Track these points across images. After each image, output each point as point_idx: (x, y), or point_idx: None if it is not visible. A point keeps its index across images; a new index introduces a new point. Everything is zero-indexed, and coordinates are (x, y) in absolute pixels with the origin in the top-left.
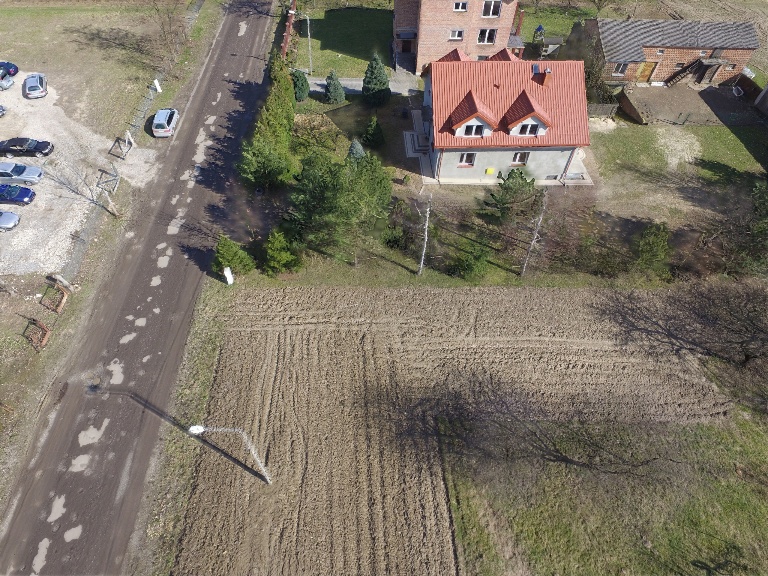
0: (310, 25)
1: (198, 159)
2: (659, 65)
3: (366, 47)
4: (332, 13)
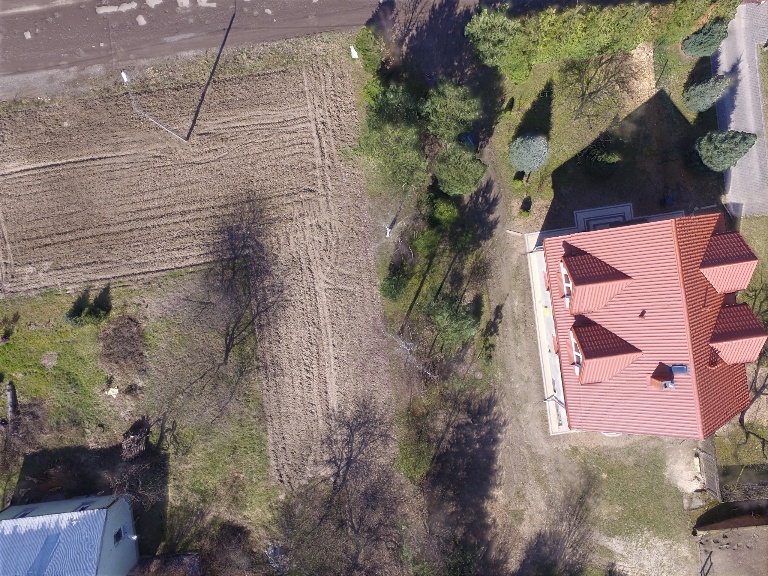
0: None
1: None
2: None
3: None
4: None
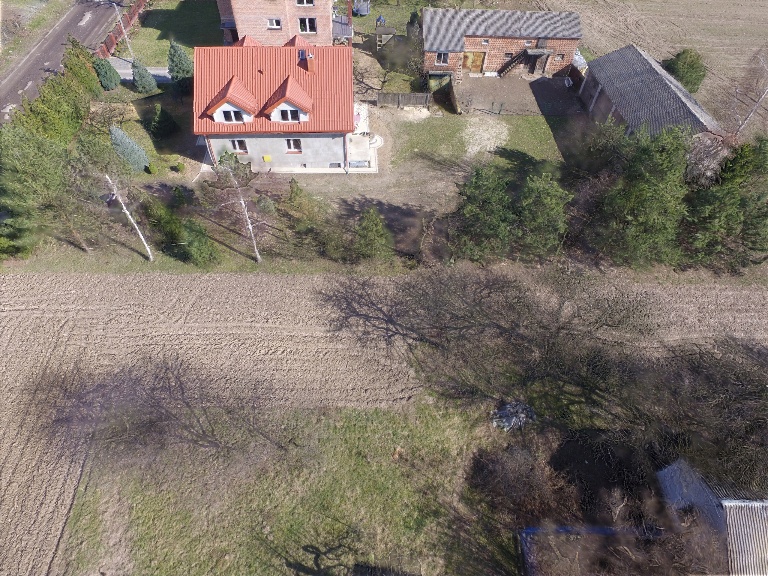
0: (157, 15)
1: None
2: (488, 55)
3: (205, 37)
4: (186, 4)
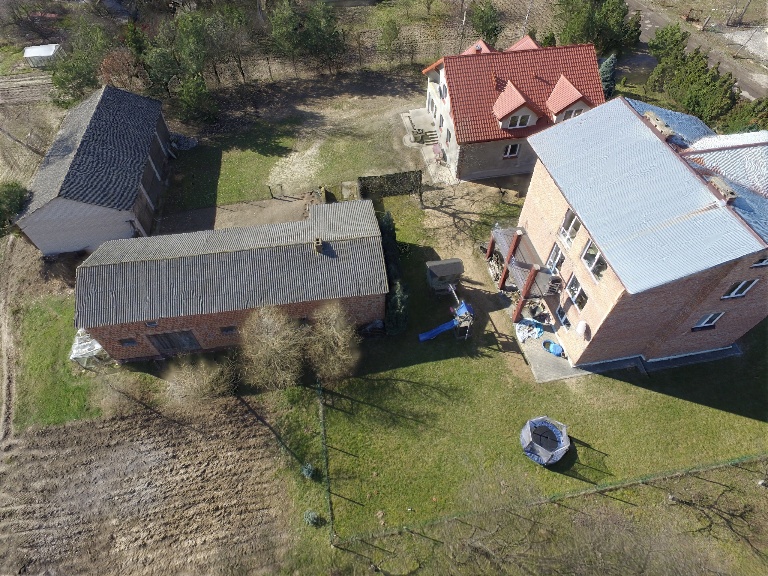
0: None
1: (742, 92)
2: None
3: None
4: None
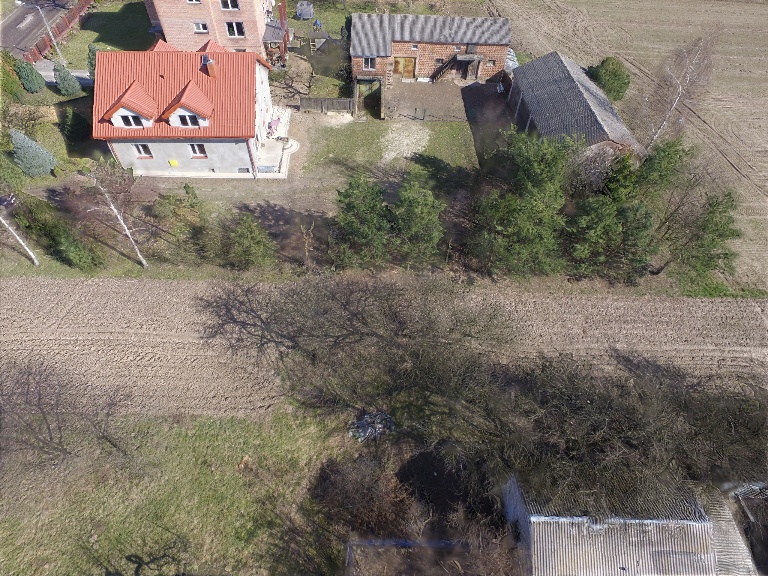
0: (99, 18)
1: None
2: (419, 60)
3: (142, 40)
4: (130, 6)
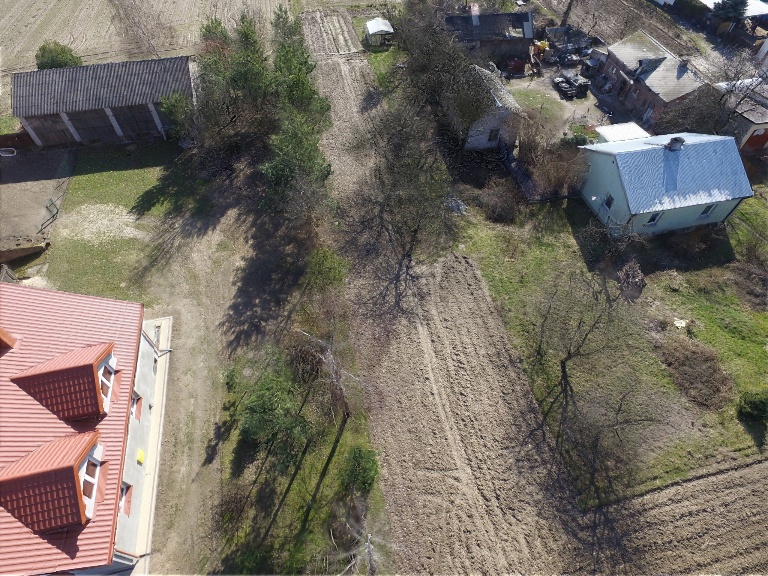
0: None
1: None
2: None
3: None
4: None
